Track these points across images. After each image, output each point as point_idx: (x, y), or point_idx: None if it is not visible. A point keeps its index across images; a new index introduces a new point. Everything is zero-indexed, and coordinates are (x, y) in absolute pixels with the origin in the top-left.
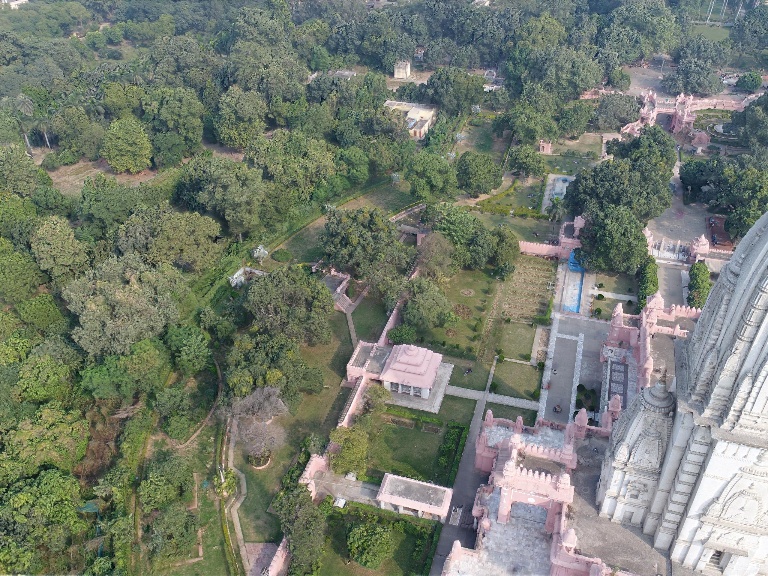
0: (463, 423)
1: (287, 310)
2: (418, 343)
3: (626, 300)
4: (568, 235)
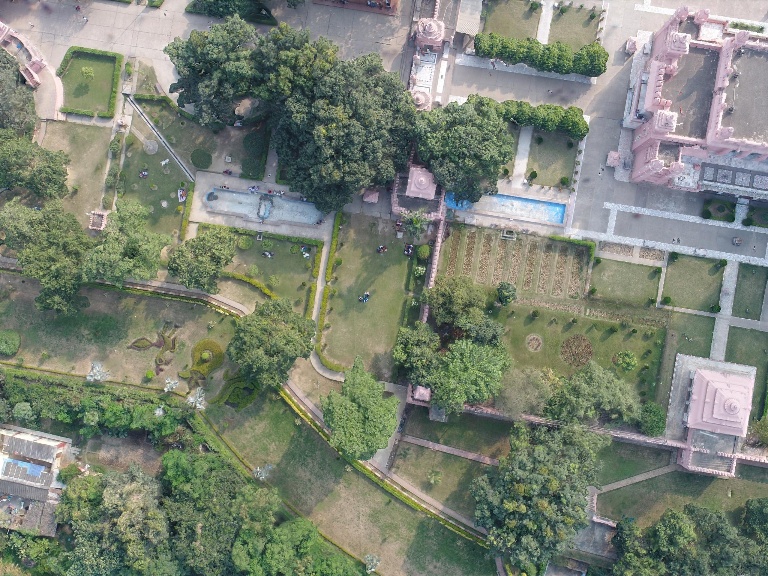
0: (767, 340)
1: (724, 570)
2: (645, 399)
3: (530, 144)
4: (429, 208)
